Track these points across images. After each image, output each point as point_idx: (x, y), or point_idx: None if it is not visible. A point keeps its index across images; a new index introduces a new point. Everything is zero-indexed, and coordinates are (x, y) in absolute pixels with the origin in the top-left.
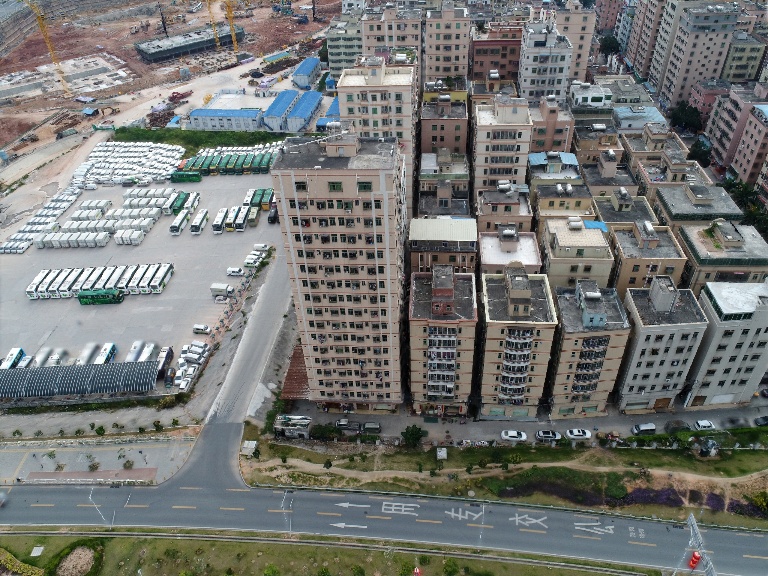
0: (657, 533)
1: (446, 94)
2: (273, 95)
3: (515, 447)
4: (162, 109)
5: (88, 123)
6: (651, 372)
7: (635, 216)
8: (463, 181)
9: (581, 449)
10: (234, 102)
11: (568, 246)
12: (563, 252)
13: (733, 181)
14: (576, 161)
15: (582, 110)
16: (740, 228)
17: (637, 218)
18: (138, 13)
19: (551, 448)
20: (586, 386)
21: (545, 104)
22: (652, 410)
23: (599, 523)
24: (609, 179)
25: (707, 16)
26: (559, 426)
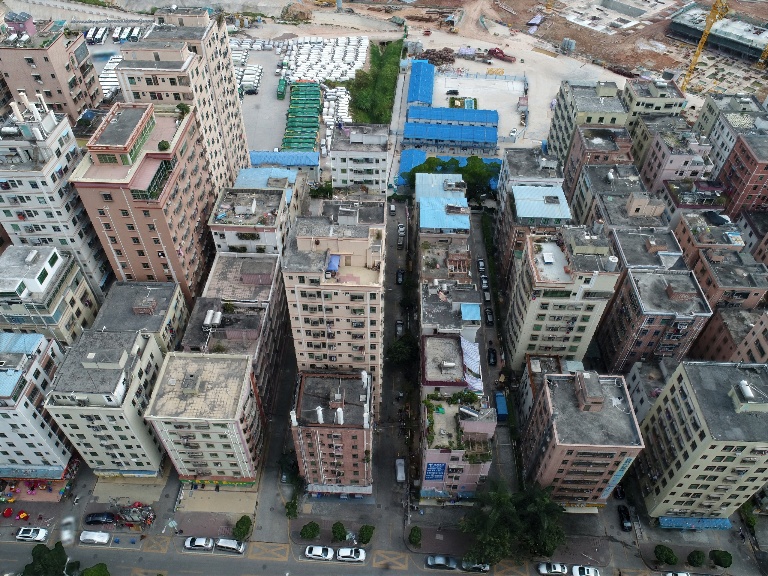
0: None
1: None
2: (522, 114)
3: None
4: (462, 52)
5: (431, 26)
6: None
7: None
8: None
9: None
10: (495, 92)
11: None
12: None
13: None
14: None
15: None
16: None
17: None
18: None
19: None
20: None
21: None
22: None
23: None
24: None
25: None
26: None
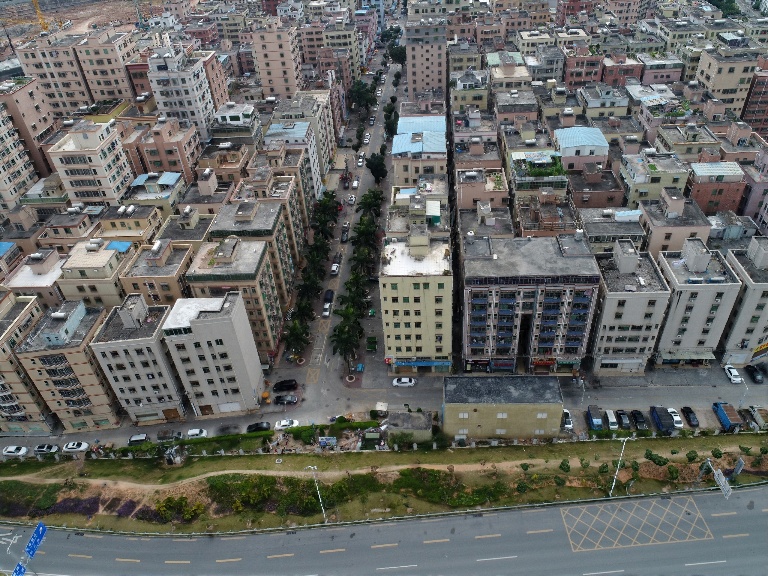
0: (55, 541)
1: (79, 119)
2: None
3: (5, 462)
4: None
5: None
6: (135, 385)
7: (193, 234)
8: (61, 204)
9: (62, 462)
10: None
11: (68, 268)
12: (67, 274)
13: (373, 192)
14: (174, 181)
15: (222, 129)
16: (251, 244)
17: (193, 236)
18: (11, 33)
19: (36, 462)
20: (76, 401)
21: (154, 126)
22: (164, 420)
23: (10, 533)
24: (206, 197)
25: (417, 29)
26: (67, 440)
